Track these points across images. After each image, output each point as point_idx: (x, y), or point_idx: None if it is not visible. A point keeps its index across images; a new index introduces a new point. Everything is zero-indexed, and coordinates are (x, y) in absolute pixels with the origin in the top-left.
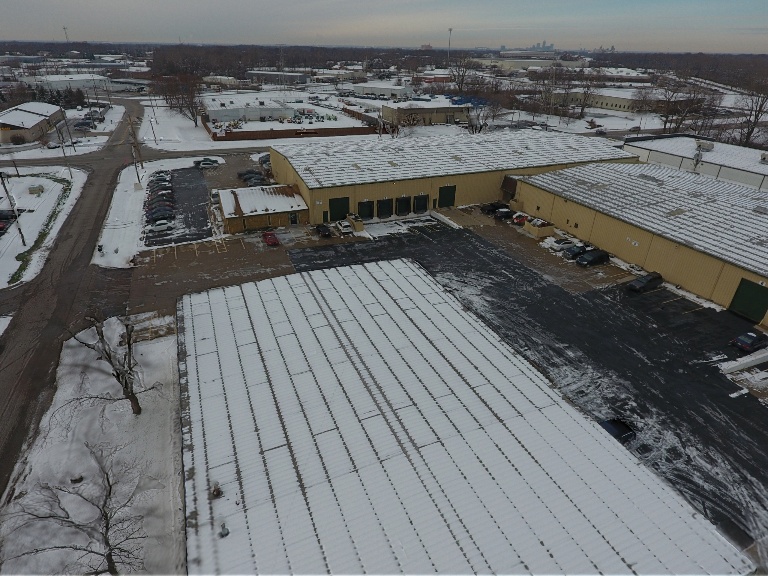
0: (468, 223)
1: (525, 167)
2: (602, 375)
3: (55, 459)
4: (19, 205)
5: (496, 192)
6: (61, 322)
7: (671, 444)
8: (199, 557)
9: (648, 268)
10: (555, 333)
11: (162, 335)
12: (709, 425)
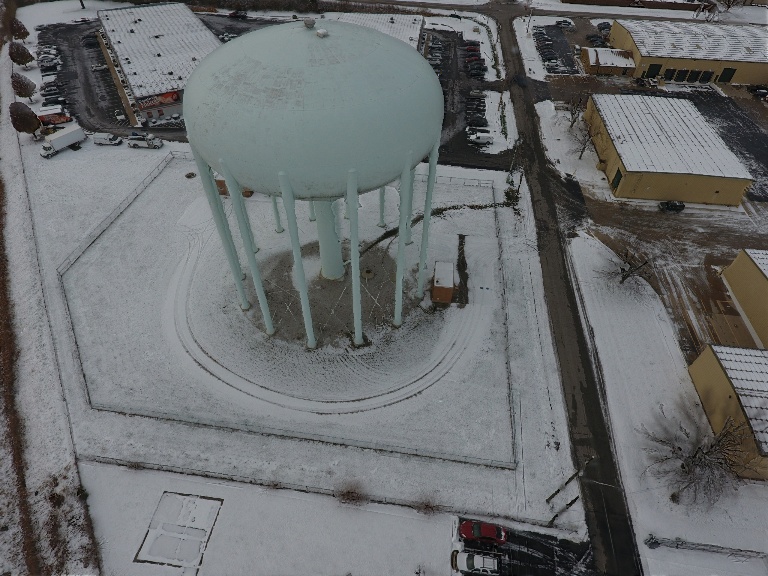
0: (733, 94)
1: None
2: (756, 164)
3: (549, 134)
4: (475, 38)
5: (766, 78)
6: (529, 97)
7: (766, 183)
8: (617, 144)
9: None
10: (746, 148)
11: None
12: None
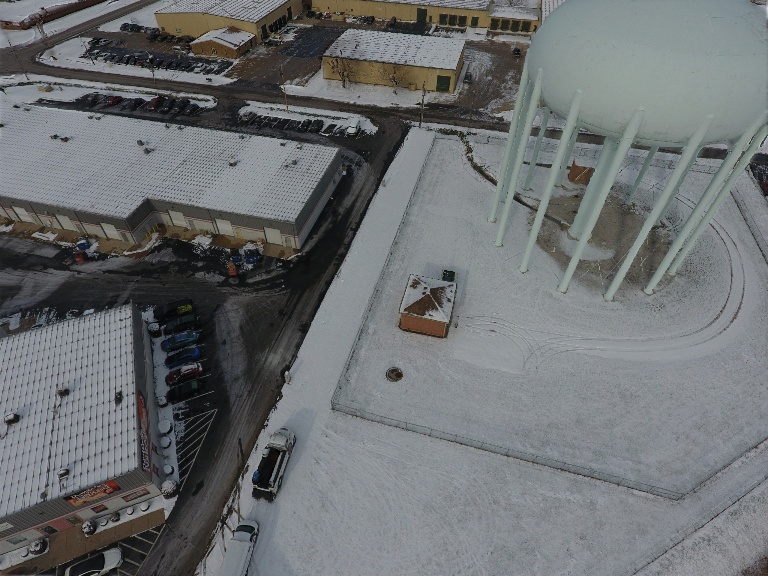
0: (311, 23)
1: None
2: None
3: (347, 98)
4: (78, 94)
5: (301, 6)
6: None
7: None
8: None
9: (387, 18)
10: None
11: None
12: None
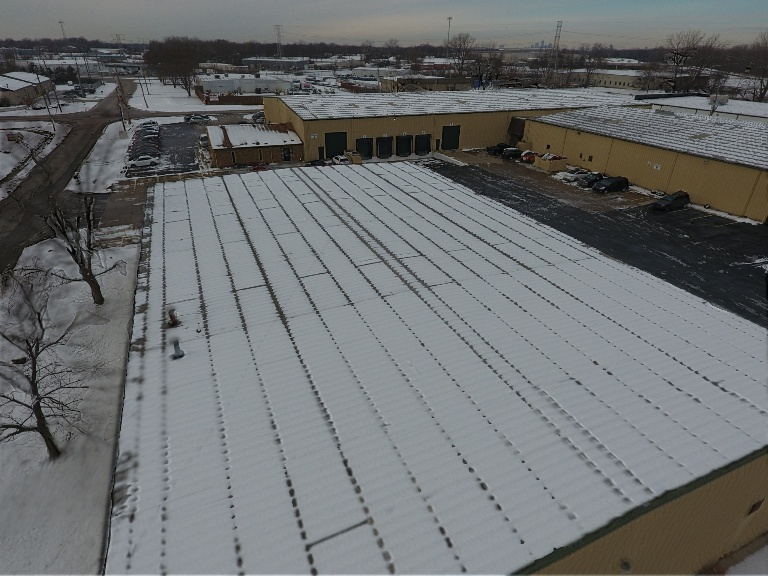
0: (474, 161)
1: (533, 109)
2: None
3: None
4: None
5: (502, 135)
6: (24, 233)
7: None
8: (141, 376)
9: (671, 192)
10: None
11: (136, 243)
12: (762, 314)
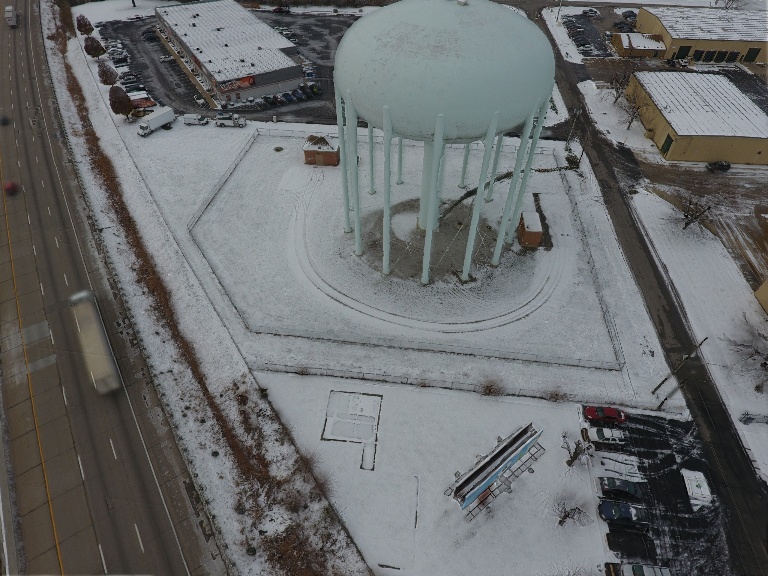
0: (759, 72)
1: None
2: None
3: (596, 109)
4: None
5: None
6: (570, 78)
7: None
8: None
9: None
10: None
11: (610, 88)
12: None
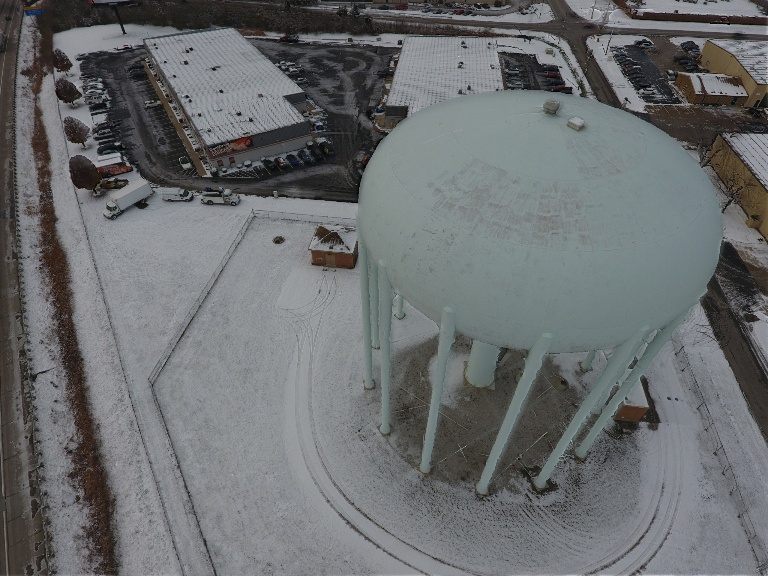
0: None
1: None
2: None
3: None
4: (552, 62)
5: None
6: None
7: None
8: None
9: None
10: None
11: (687, 149)
12: None
